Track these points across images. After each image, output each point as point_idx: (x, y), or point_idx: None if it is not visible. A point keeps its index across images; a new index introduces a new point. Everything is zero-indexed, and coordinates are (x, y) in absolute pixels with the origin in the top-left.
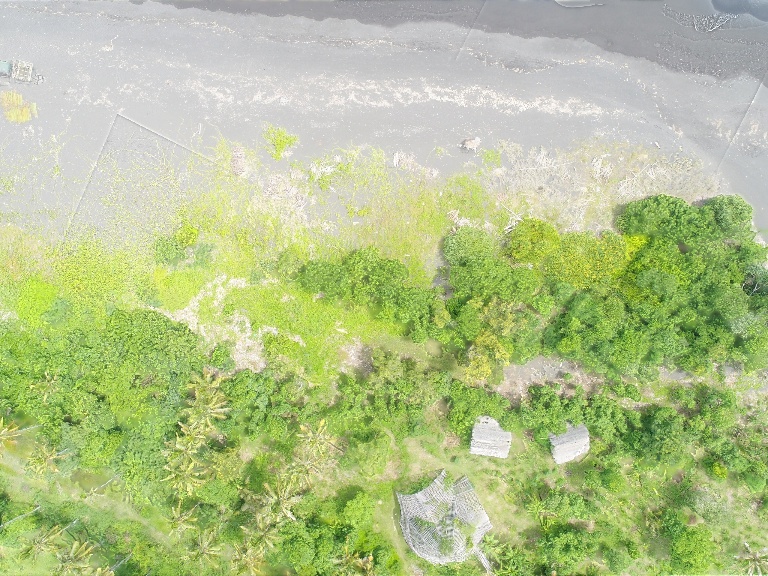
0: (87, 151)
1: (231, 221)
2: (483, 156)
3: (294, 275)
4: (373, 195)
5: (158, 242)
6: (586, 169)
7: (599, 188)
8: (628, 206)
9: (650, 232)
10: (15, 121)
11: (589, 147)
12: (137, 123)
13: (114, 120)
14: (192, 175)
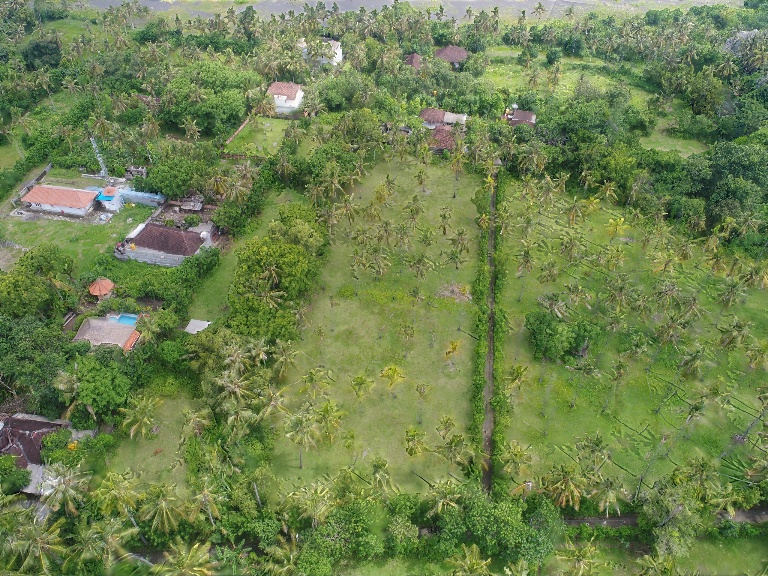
0: (548, 5)
1: (609, 14)
2: (687, 1)
3: (640, 19)
4: (656, 7)
5: (587, 14)
6: (723, 2)
7: (730, 4)
8: (744, 1)
9: (756, 5)
10: (520, 1)
11: (720, 0)
12: (564, 0)
13: (556, 0)
14: (589, 7)
